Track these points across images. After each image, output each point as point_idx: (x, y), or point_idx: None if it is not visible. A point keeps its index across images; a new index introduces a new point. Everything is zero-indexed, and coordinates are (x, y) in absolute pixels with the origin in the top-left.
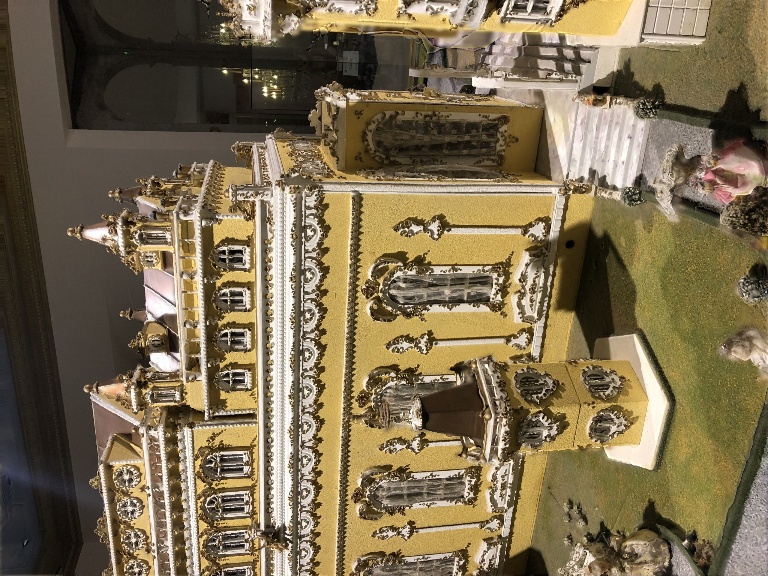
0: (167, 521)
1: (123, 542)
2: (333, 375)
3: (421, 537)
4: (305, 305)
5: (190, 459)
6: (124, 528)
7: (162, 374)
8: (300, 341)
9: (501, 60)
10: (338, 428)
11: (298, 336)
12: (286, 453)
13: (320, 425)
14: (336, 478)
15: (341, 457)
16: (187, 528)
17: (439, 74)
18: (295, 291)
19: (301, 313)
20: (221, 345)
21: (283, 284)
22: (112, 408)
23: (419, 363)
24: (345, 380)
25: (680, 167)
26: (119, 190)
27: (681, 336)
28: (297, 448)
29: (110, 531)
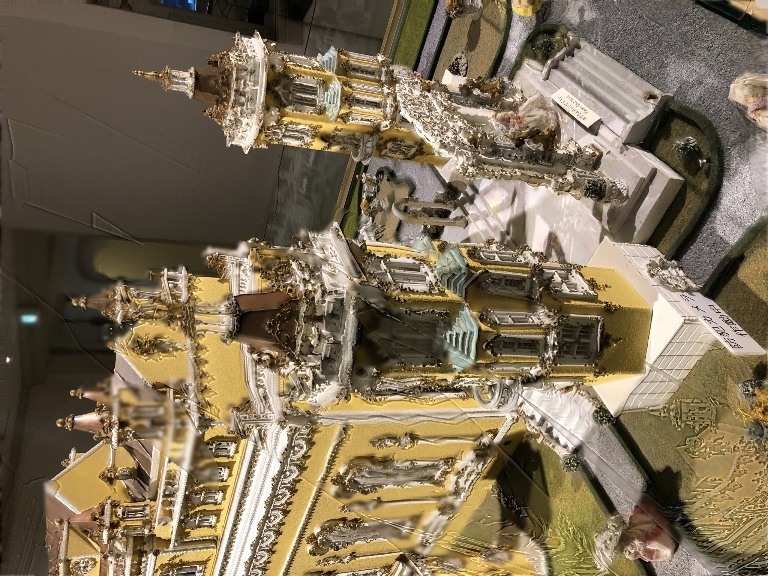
0: None
1: None
2: (291, 527)
3: None
4: (280, 490)
5: (150, 572)
6: None
7: (132, 509)
8: (269, 512)
9: (482, 226)
10: (285, 555)
11: (268, 509)
12: (238, 573)
13: (271, 555)
14: None
15: (283, 572)
16: None
17: (422, 222)
18: (274, 486)
19: (275, 496)
20: (194, 500)
21: (264, 480)
22: (70, 506)
23: None
24: (300, 531)
25: (619, 548)
26: None
27: None
28: (248, 570)
29: None
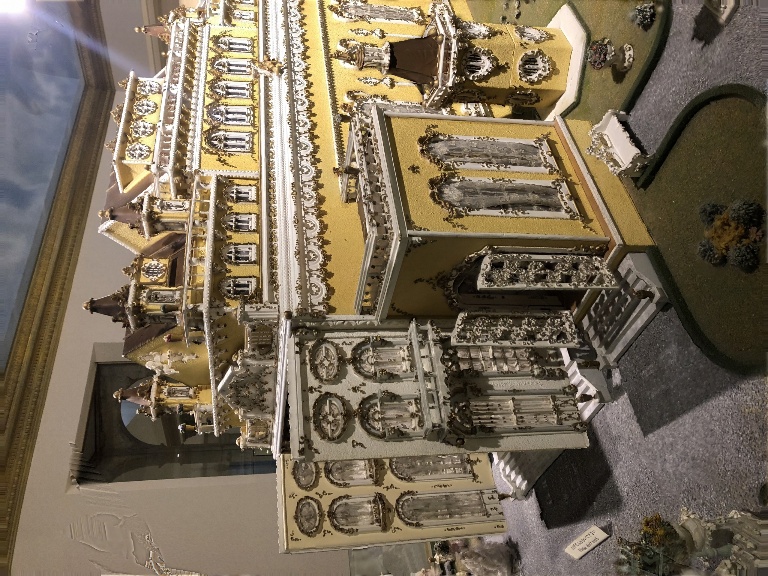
0: (181, 68)
1: (132, 128)
2: None
3: (403, 90)
4: None
5: (206, 40)
6: (136, 117)
7: None
8: None
9: None
10: (317, 20)
11: None
12: (279, 24)
13: (303, 16)
14: (320, 45)
15: (321, 30)
16: (196, 79)
17: None
18: None
19: None
20: None
21: None
22: None
23: (367, 0)
24: None
25: None
26: None
27: None
28: (287, 23)
29: (124, 113)
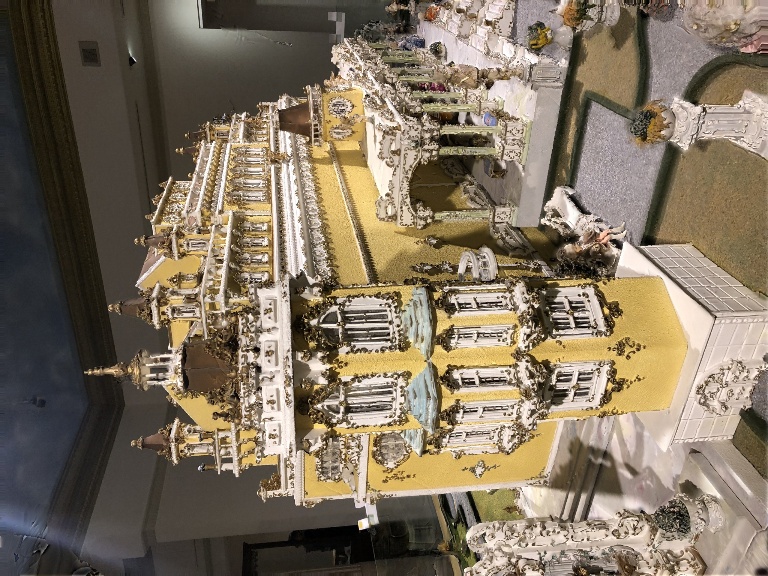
0: None
1: None
2: None
3: None
4: None
5: None
6: None
7: None
8: None
9: None
10: None
11: None
12: None
13: None
14: None
15: None
16: None
17: None
18: None
19: None
20: None
21: None
22: None
23: None
24: None
25: None
26: (119, 308)
27: (503, 515)
28: None
29: None
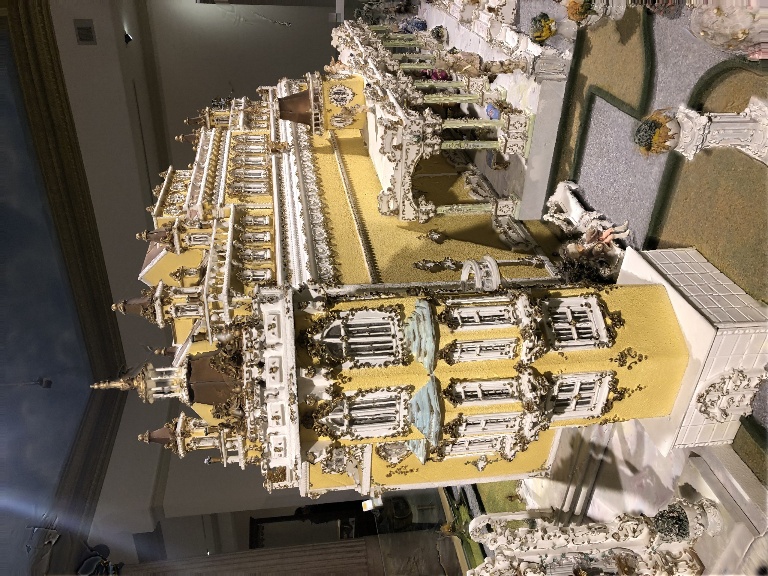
0: None
1: None
2: None
3: None
4: None
5: None
6: None
7: None
8: None
9: None
10: None
11: None
12: None
13: None
14: None
15: None
16: None
17: None
18: None
19: None
20: None
21: None
22: None
23: None
24: None
25: None
26: (123, 307)
27: None
28: None
29: None
